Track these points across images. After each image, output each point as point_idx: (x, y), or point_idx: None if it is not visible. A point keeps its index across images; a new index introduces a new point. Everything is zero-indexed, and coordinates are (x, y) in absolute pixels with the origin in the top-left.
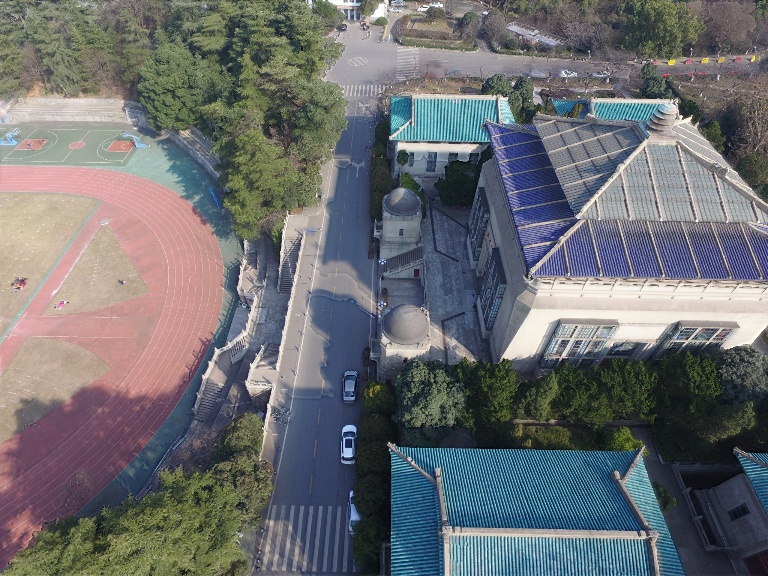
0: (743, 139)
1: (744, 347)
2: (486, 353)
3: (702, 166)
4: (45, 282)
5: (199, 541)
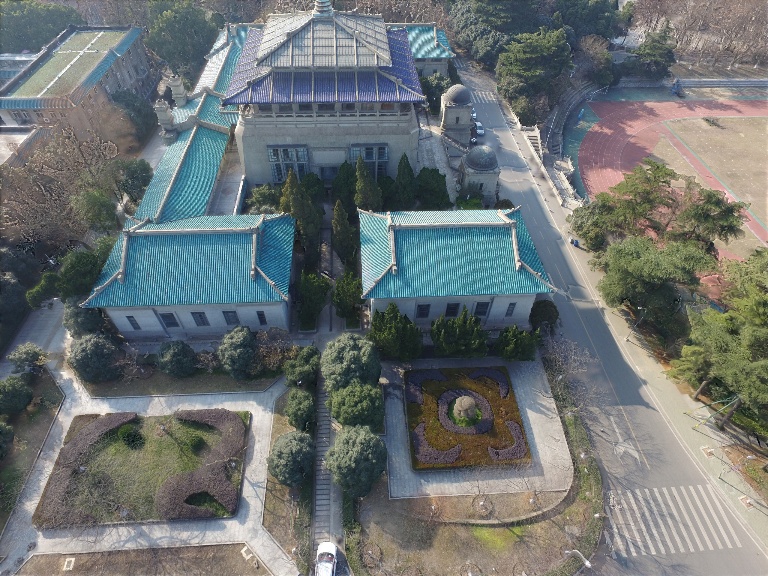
0: None
1: None
2: None
3: None
4: (761, 225)
5: None
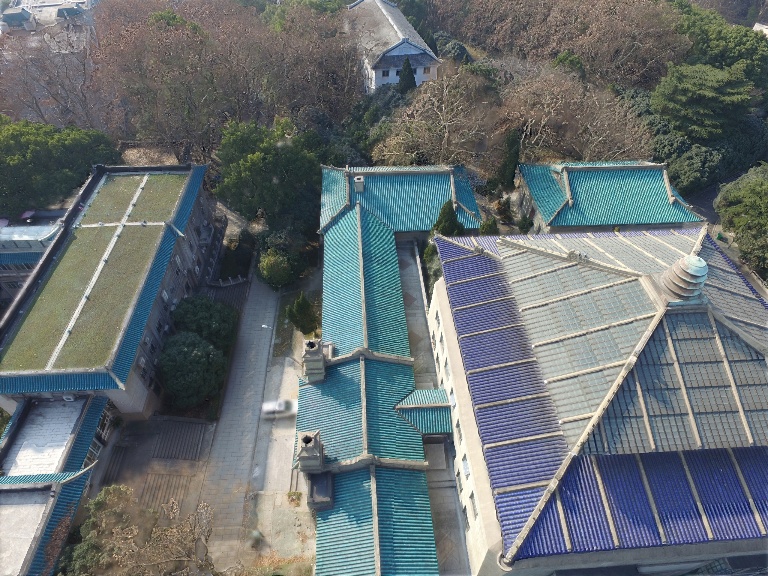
0: None
1: None
2: None
3: None
4: None
5: (765, 199)
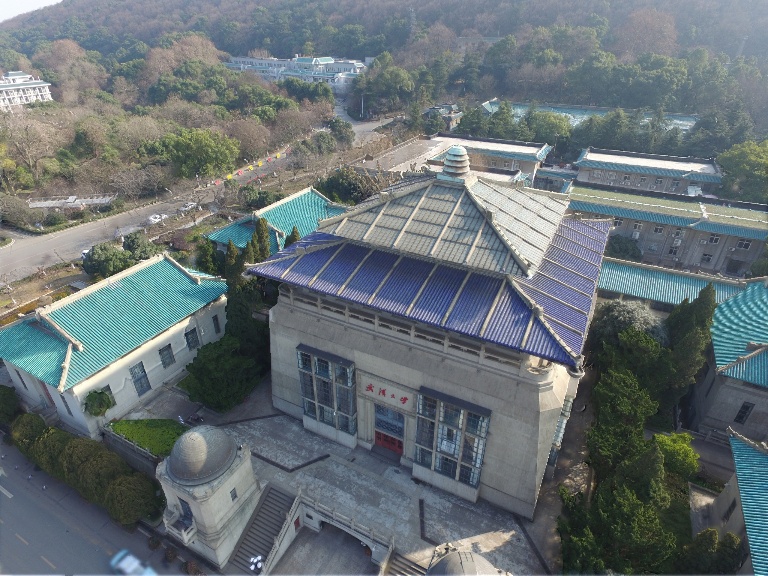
0: (358, 199)
1: (609, 305)
2: (499, 513)
3: (506, 187)
4: None
5: None
